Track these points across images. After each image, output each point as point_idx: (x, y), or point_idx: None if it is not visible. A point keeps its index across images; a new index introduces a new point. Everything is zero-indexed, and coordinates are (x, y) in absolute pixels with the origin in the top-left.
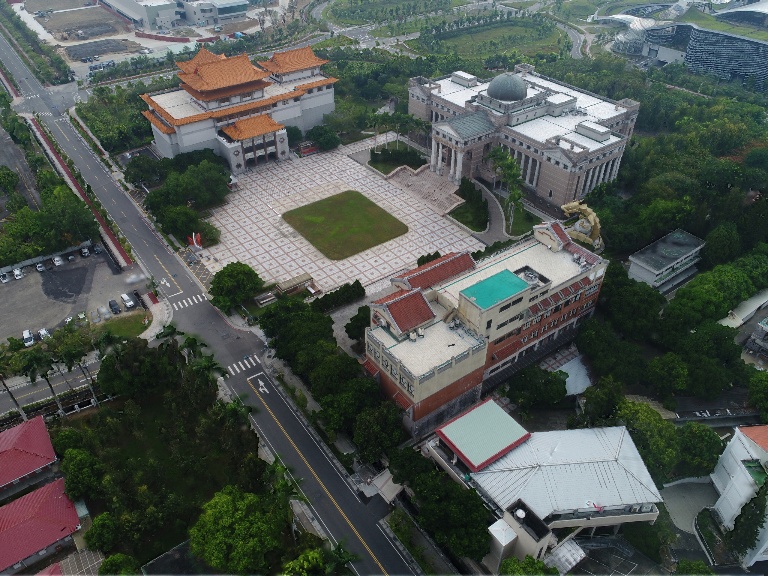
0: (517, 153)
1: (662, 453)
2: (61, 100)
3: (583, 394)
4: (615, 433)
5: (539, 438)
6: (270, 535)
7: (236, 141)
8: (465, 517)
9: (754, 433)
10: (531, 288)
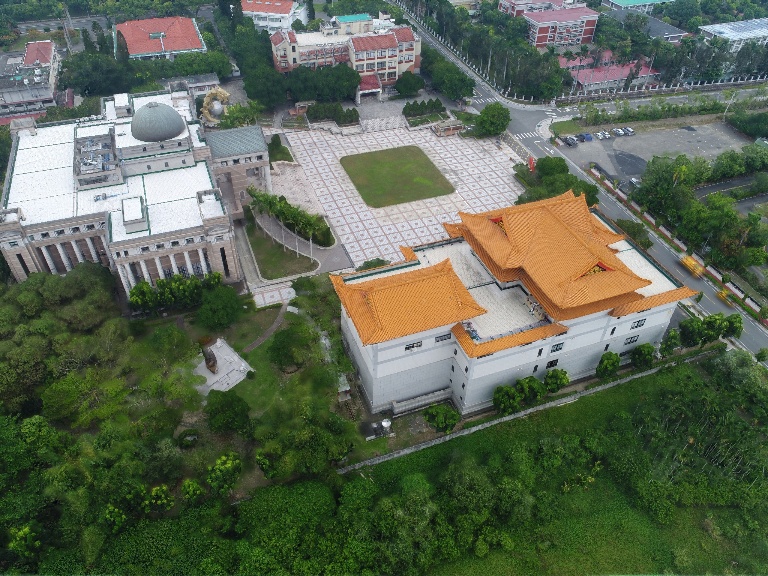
0: None
1: None
2: None
3: None
4: None
5: None
6: None
7: None
8: None
9: (286, 11)
10: None
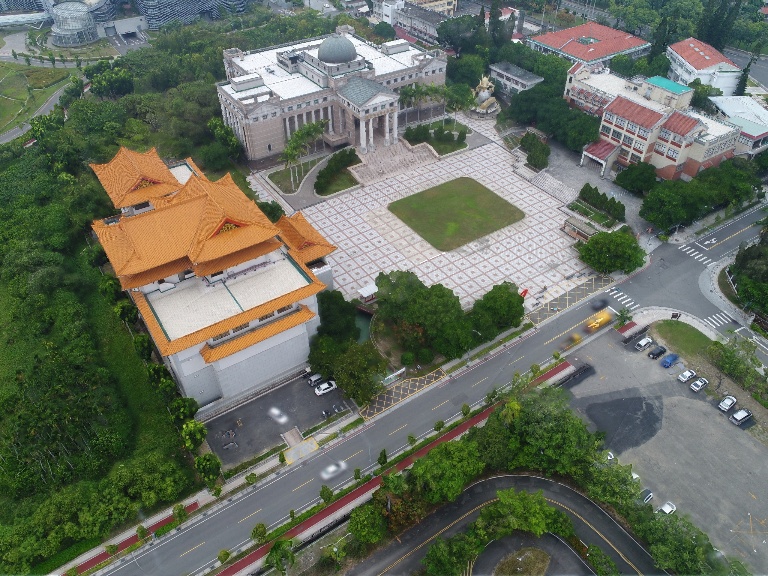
0: None
1: None
2: None
3: None
4: None
5: None
6: None
7: None
8: None
9: (701, 67)
10: None
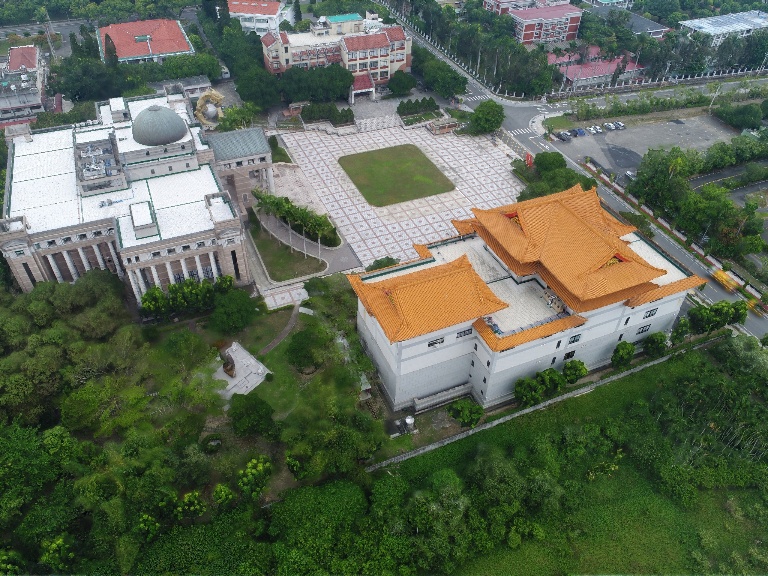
0: None
1: None
2: None
3: None
4: None
5: None
6: None
7: None
8: None
9: (273, 12)
10: None
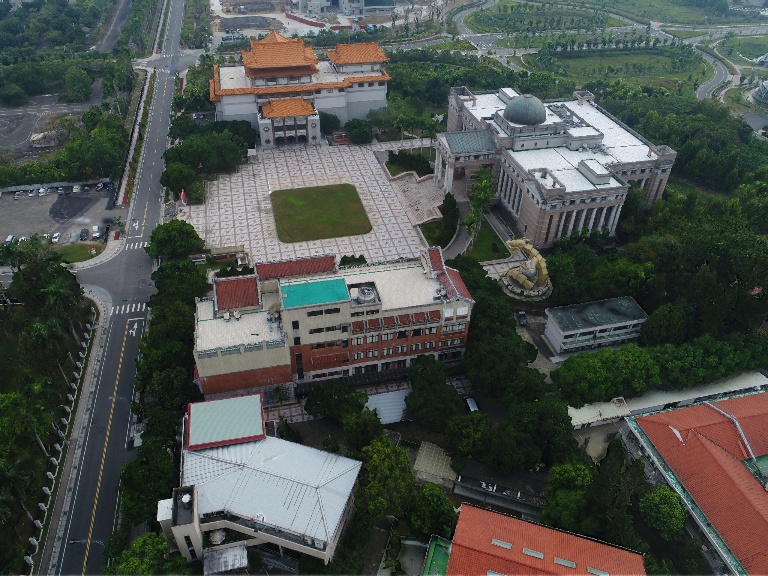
0: (511, 179)
1: (373, 500)
2: (185, 62)
3: (396, 427)
4: (345, 465)
5: (271, 443)
6: (2, 439)
7: (267, 118)
8: (145, 483)
9: (471, 515)
10: (361, 303)
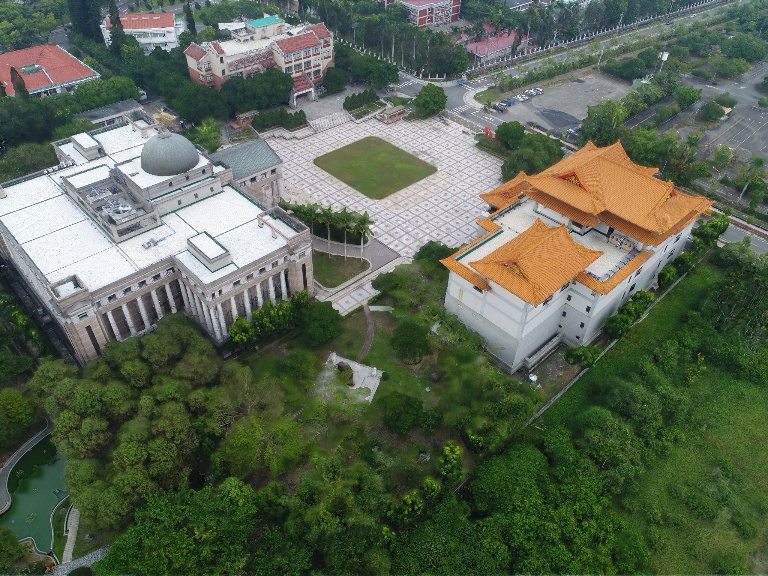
0: None
1: None
2: None
3: None
4: None
5: None
6: None
7: None
8: None
9: (169, 24)
10: None
